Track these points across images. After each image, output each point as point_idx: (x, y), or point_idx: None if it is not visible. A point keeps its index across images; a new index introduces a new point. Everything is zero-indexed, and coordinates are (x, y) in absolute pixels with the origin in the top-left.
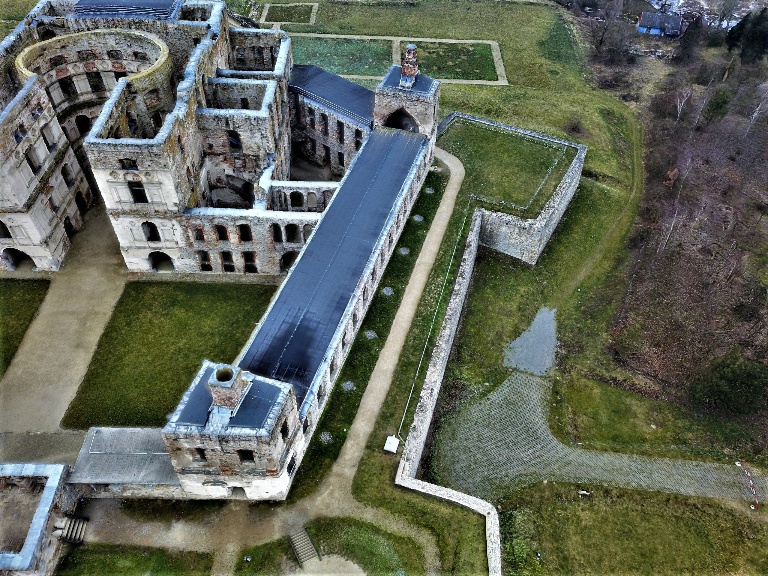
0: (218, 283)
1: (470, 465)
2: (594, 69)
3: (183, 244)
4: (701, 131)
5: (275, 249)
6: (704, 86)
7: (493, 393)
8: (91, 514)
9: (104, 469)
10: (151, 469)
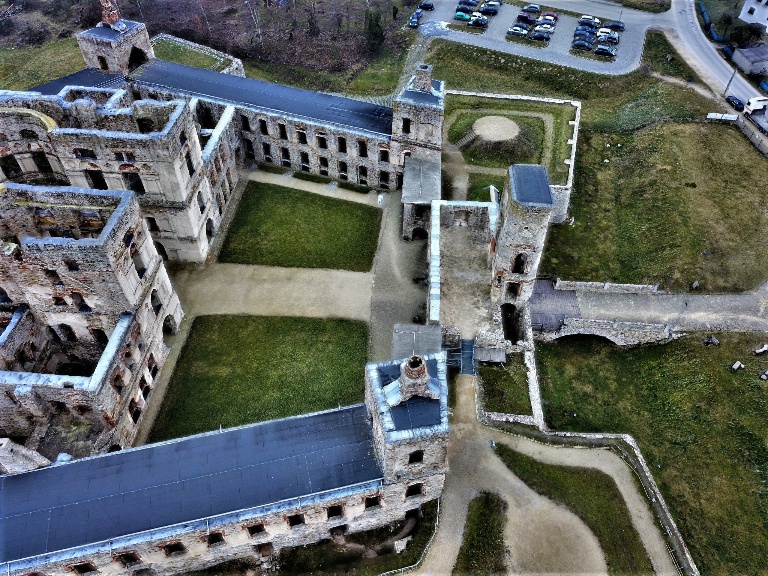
0: (236, 210)
1: None
2: (6, 43)
3: (211, 198)
4: (136, 15)
5: (232, 155)
6: (75, 5)
7: None
8: None
9: (432, 191)
10: (432, 173)
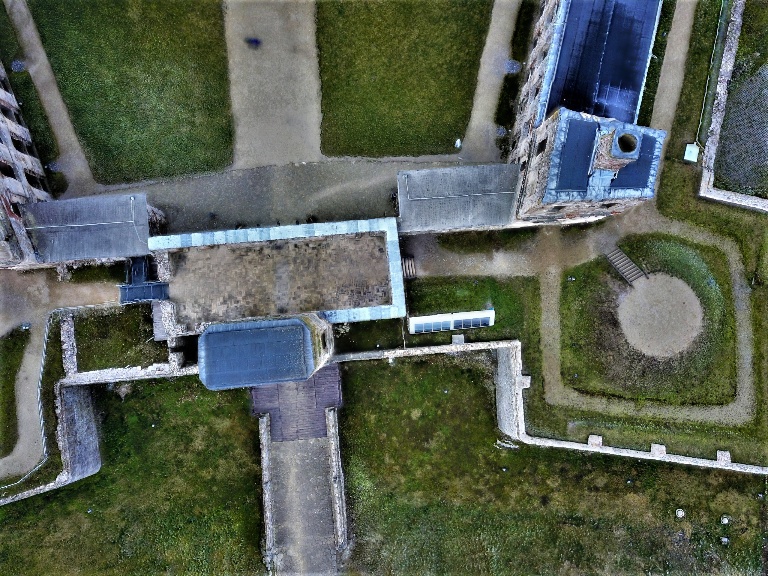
0: None
1: (741, 154)
2: None
3: None
4: None
5: None
6: None
7: (765, 66)
8: (414, 251)
9: (431, 216)
10: (478, 211)
